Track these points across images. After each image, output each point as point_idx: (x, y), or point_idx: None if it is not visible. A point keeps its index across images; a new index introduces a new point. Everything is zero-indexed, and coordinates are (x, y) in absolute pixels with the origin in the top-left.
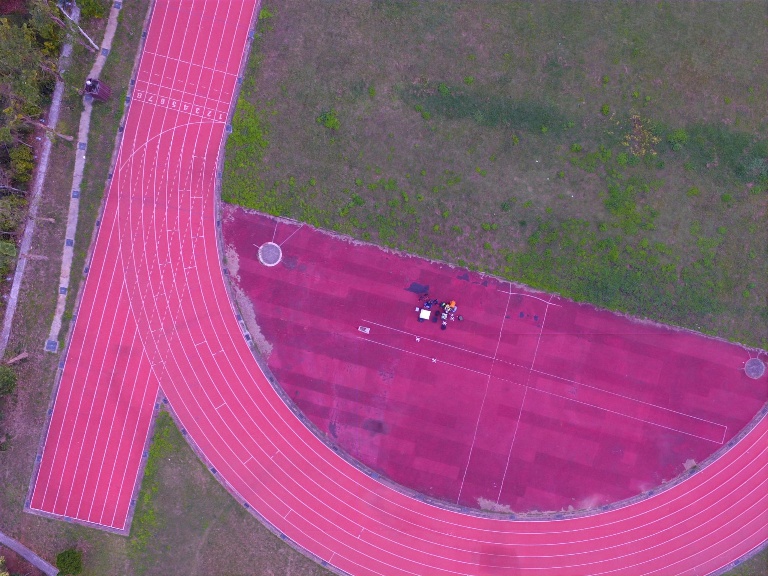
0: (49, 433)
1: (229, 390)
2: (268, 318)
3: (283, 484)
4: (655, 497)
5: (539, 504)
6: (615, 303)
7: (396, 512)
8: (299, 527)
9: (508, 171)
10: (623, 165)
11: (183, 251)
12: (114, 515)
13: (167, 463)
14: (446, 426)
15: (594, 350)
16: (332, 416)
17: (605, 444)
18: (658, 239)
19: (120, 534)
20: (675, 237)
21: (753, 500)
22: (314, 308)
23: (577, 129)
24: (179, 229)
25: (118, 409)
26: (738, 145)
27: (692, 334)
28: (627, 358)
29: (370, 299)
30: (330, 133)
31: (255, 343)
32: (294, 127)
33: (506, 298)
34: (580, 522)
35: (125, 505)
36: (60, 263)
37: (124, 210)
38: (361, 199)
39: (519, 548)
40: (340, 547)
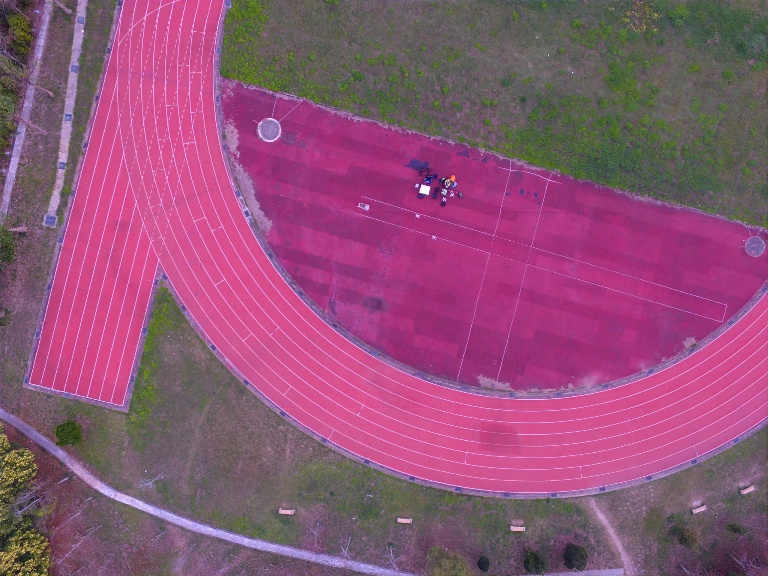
0: (48, 308)
1: (228, 266)
2: (267, 194)
3: (283, 361)
4: (655, 375)
5: (539, 382)
6: (615, 180)
7: (396, 389)
8: (299, 404)
9: (508, 47)
10: (624, 41)
11: (182, 126)
12: (113, 391)
13: (166, 339)
14: (446, 303)
15: (594, 227)
16: (332, 293)
17: (605, 322)
18: (659, 116)
19: (119, 410)
20: (676, 114)
21: (753, 378)
22: (314, 184)
23: (578, 5)
24: (178, 104)
25: (117, 285)
26: (739, 21)
27: (692, 212)
28: (627, 236)
29: (370, 176)
30: (330, 8)
31: (254, 219)
32: (293, 2)
33: (506, 175)
34: (580, 400)
35: (124, 381)
36: (59, 138)
37: (123, 85)
38: (361, 74)
39: (519, 426)
40: (340, 424)
